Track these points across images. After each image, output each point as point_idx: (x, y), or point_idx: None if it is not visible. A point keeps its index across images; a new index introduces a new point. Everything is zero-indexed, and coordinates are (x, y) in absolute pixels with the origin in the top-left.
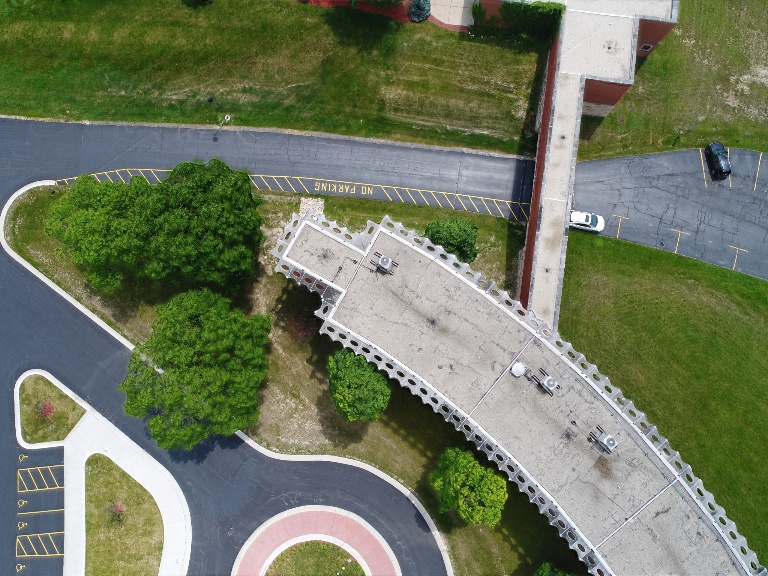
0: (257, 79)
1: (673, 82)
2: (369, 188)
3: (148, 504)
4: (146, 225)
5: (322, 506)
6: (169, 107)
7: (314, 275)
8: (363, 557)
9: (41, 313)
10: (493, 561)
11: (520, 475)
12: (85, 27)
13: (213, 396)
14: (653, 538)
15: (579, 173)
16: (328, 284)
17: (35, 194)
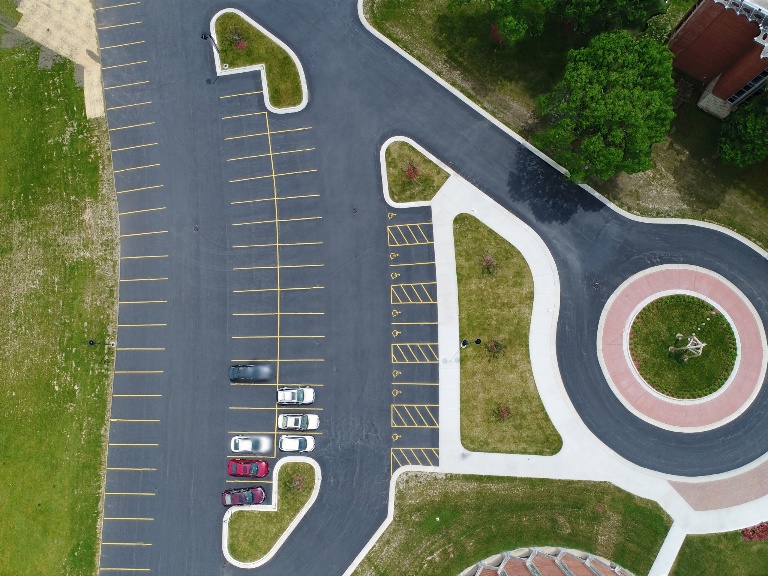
0: None
1: None
2: None
3: (517, 259)
4: None
5: (683, 265)
6: None
7: (754, 5)
8: (726, 310)
9: (402, 85)
10: None
11: None
12: None
13: (646, 120)
14: None
15: None
16: (766, 14)
17: None
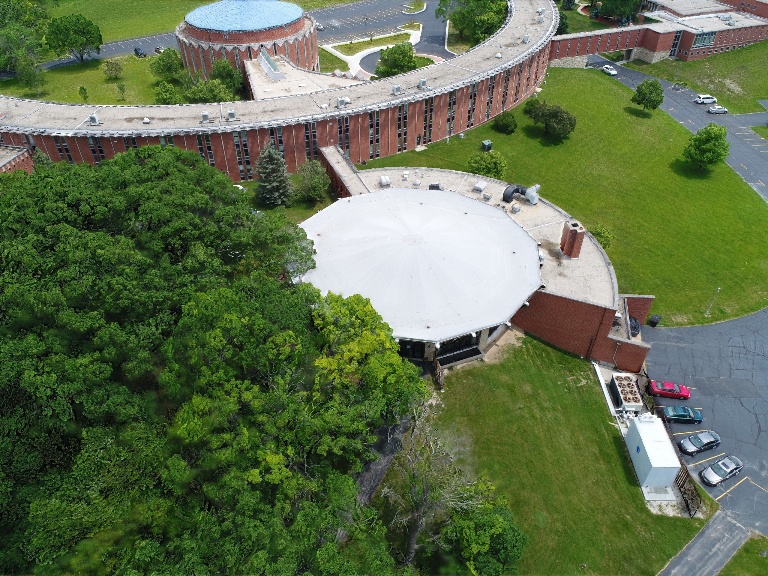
0: None
1: (688, 68)
2: None
3: None
4: None
5: None
6: None
7: None
8: None
9: None
10: None
11: None
12: None
13: None
14: None
15: (625, 69)
16: None
17: None
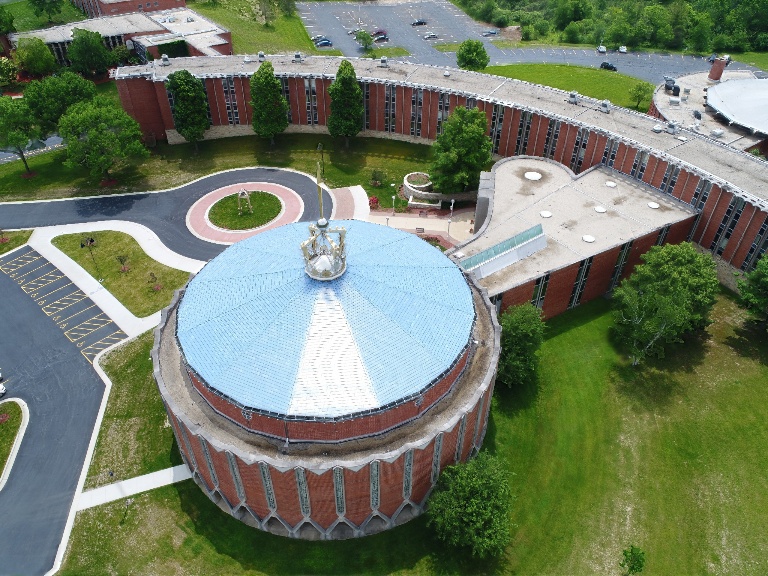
0: None
1: None
2: None
3: (110, 233)
4: None
5: None
6: None
7: (136, 74)
8: None
9: None
10: None
11: None
12: None
13: None
14: None
15: None
16: (145, 74)
17: None
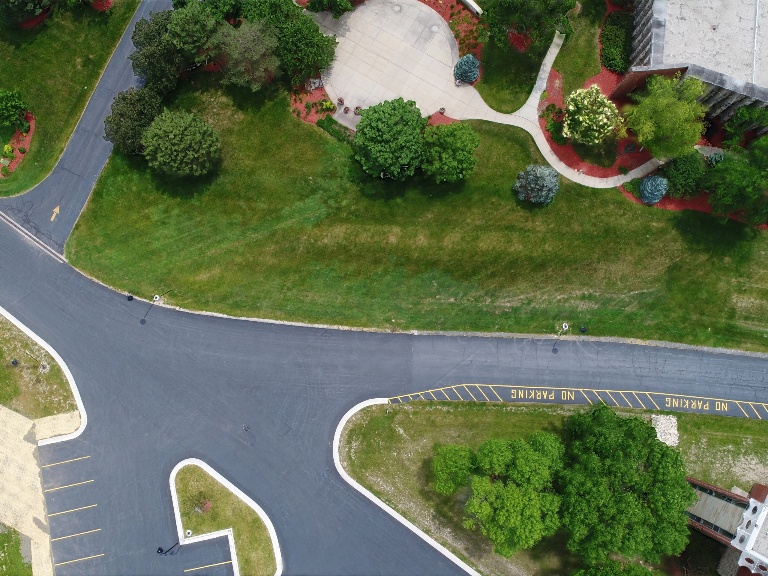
0: (598, 286)
1: None
2: (723, 404)
3: None
4: (598, 517)
5: None
6: (502, 315)
7: None
8: None
9: (387, 547)
10: None
11: None
12: (412, 231)
13: None
14: None
15: None
16: None
17: (368, 414)
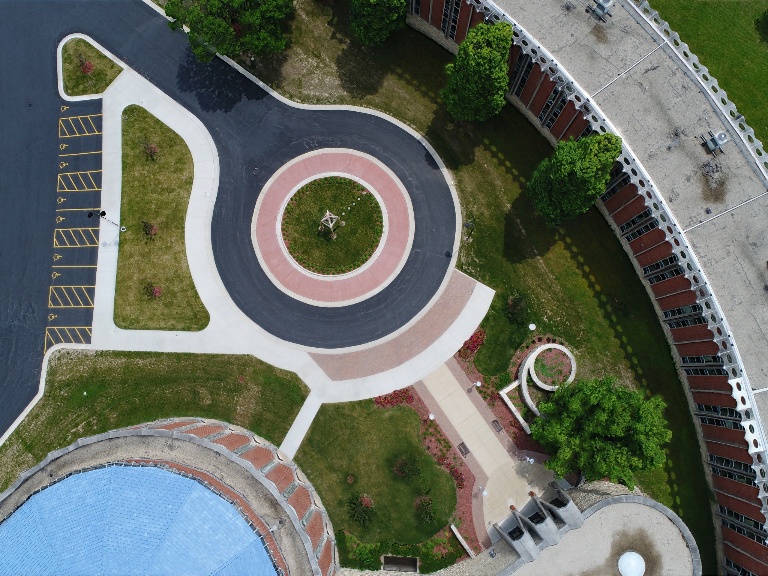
0: None
1: None
2: None
3: (180, 146)
4: None
5: (340, 148)
6: None
7: None
8: (377, 190)
9: None
10: (496, 192)
11: (524, 39)
12: None
13: None
14: (643, 90)
15: None
16: None
17: None
